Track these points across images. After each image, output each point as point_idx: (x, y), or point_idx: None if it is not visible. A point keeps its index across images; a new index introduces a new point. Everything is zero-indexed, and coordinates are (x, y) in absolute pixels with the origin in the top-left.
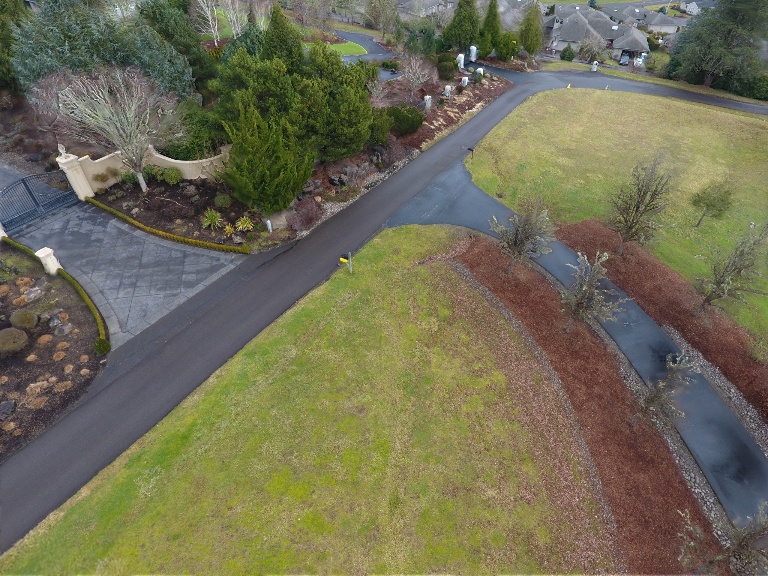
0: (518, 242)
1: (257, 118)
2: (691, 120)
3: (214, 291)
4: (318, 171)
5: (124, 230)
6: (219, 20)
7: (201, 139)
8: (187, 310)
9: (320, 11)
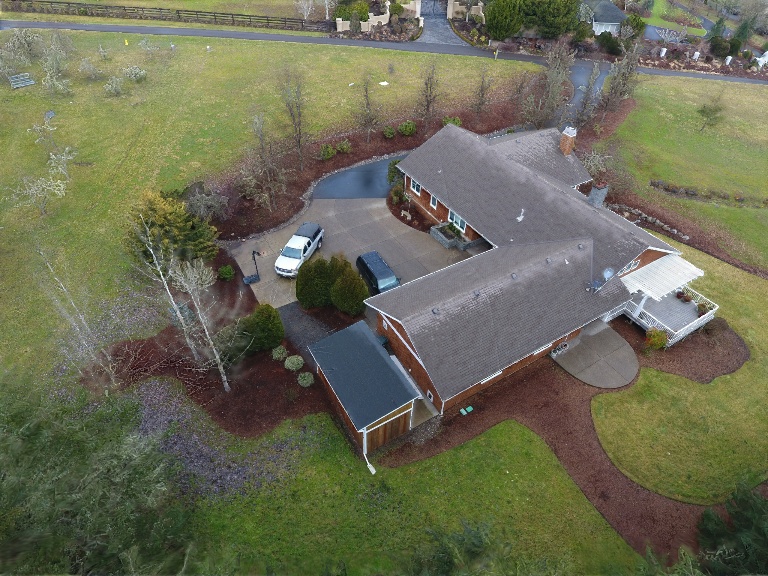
0: None
1: None
2: None
3: None
4: (533, 39)
5: (448, 28)
6: None
7: None
8: None
9: (695, 1)
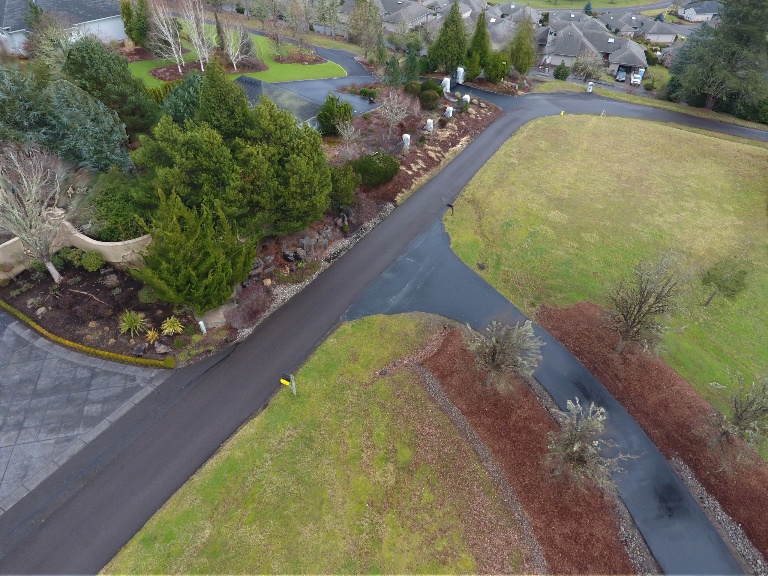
0: (497, 356)
1: (179, 208)
2: (694, 153)
3: (120, 431)
4: (269, 246)
5: (24, 338)
6: (183, 44)
7: (126, 217)
8: (81, 464)
9: (297, 29)
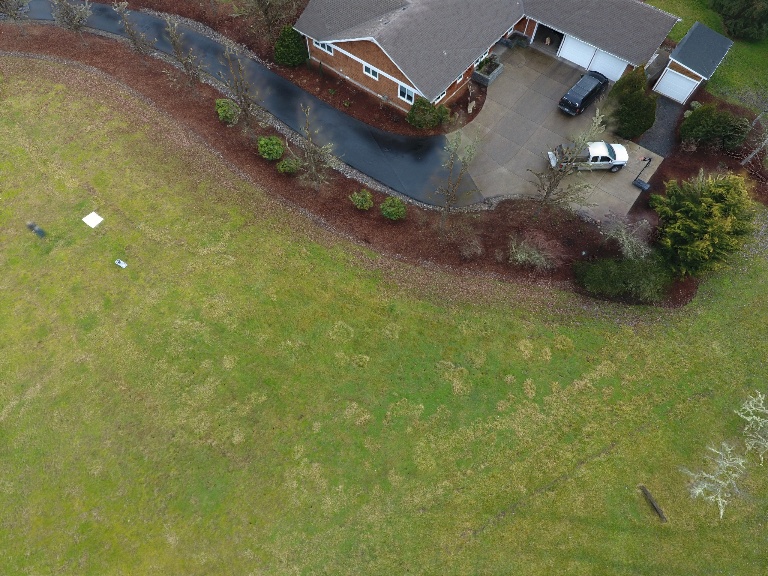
0: (3, 4)
1: None
2: None
3: None
4: None
5: None
6: None
7: None
8: None
9: None
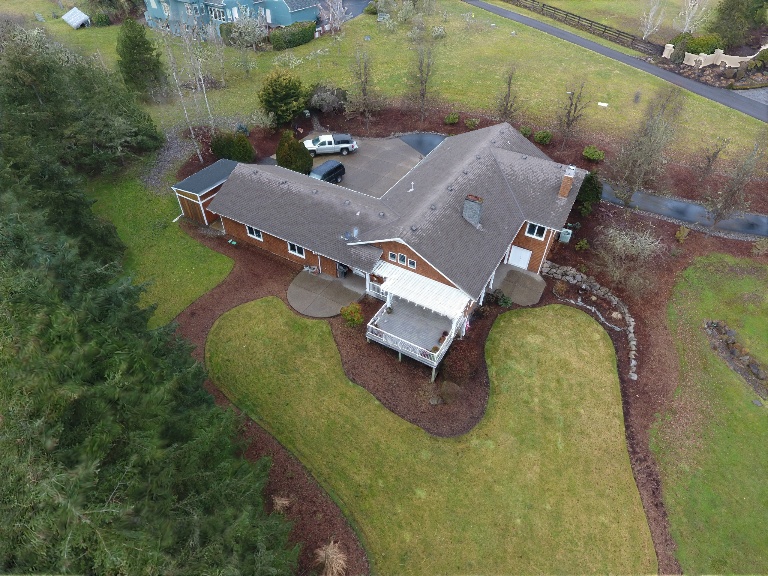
0: None
1: None
2: None
3: None
4: None
5: None
6: None
7: None
8: (756, 103)
9: None
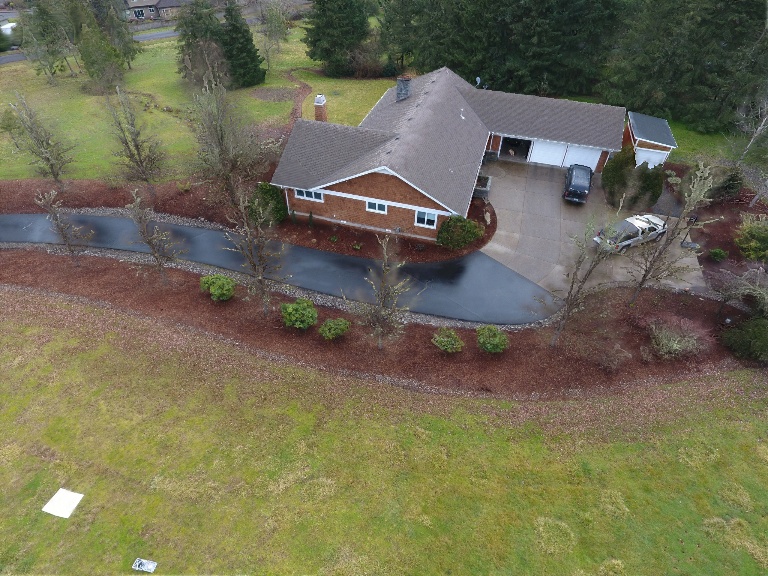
0: None
1: None
2: None
3: None
4: None
5: None
6: None
7: None
8: None
9: None
